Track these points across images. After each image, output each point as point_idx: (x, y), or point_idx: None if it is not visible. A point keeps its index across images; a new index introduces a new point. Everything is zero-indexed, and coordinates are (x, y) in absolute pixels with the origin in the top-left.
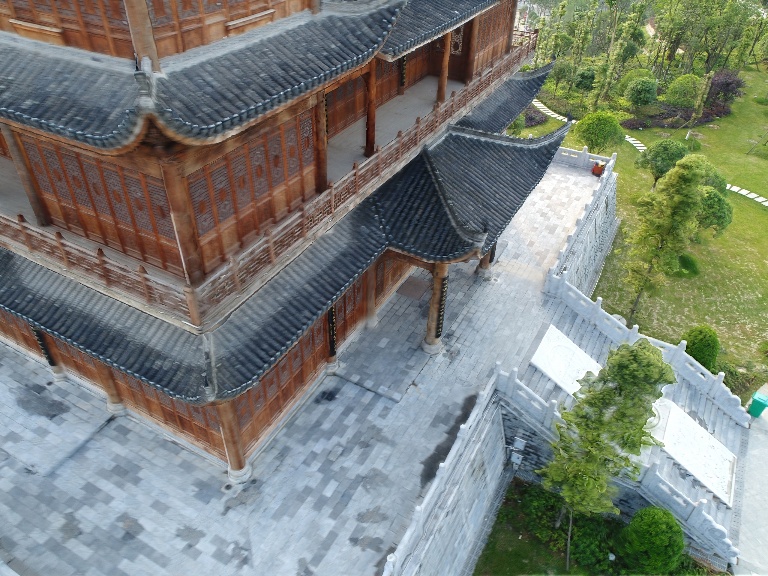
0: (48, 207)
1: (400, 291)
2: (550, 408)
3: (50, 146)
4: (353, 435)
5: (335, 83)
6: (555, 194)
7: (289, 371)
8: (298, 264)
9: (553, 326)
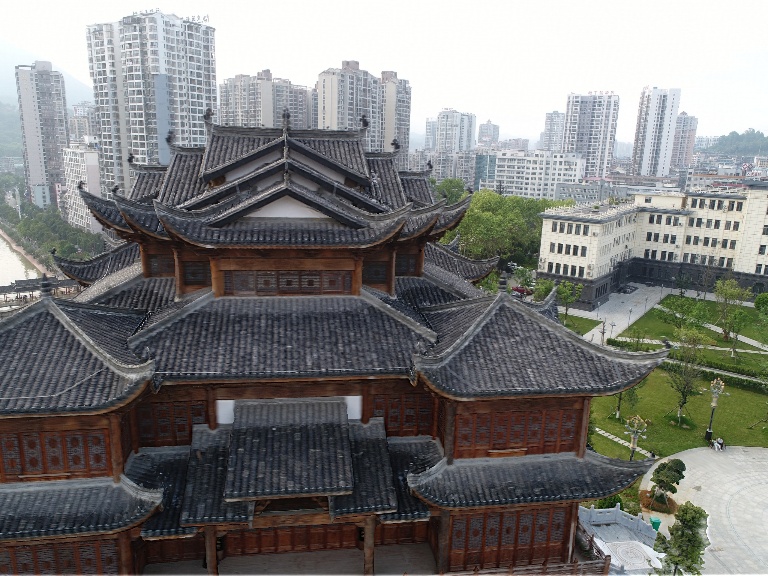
0: (451, 560)
1: None
2: (622, 570)
3: (479, 515)
4: None
5: None
6: None
7: None
8: None
9: None
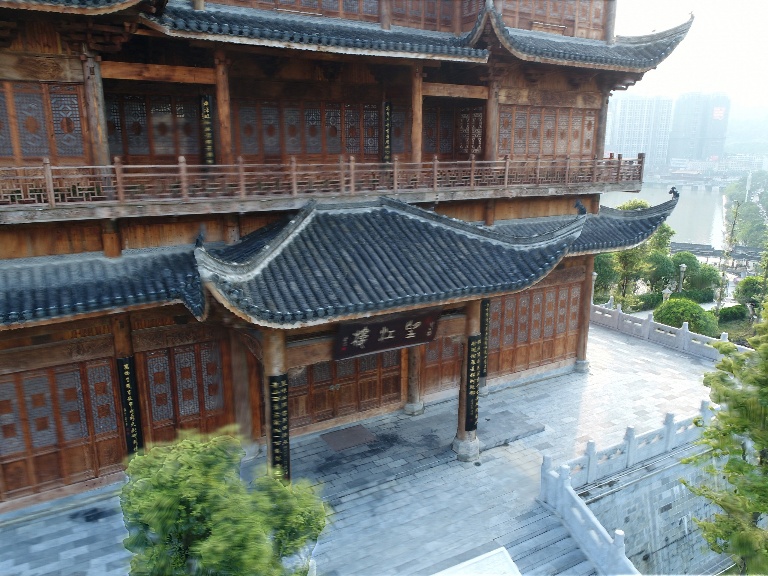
0: None
1: (326, 435)
2: None
3: None
4: (46, 572)
5: (133, 72)
6: (685, 395)
7: (23, 441)
8: (21, 272)
9: (505, 551)
